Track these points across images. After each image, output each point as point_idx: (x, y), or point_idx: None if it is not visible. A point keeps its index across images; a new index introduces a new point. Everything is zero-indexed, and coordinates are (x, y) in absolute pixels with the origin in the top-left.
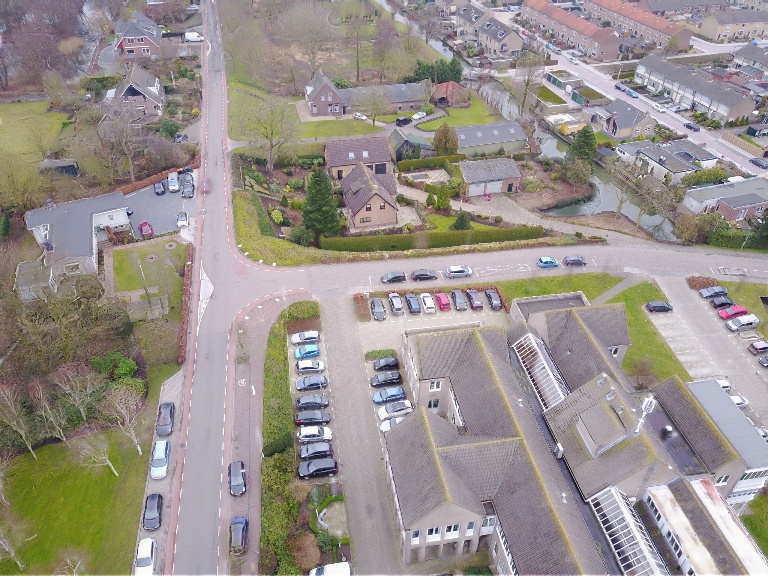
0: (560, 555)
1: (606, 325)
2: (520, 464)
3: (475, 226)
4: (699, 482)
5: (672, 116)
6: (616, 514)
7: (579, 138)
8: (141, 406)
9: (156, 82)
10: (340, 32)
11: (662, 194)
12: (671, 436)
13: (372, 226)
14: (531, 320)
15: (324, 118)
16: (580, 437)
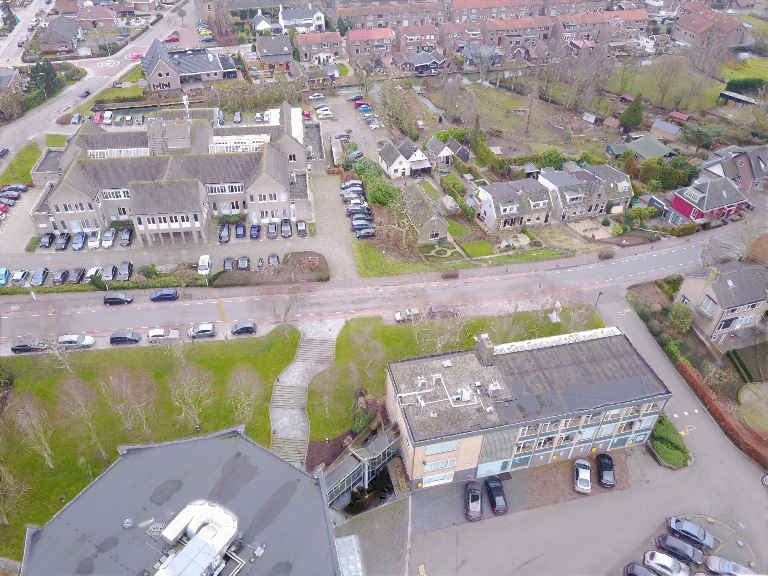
0: (239, 158)
1: None
2: (186, 162)
3: None
4: None
5: None
6: (223, 149)
7: None
8: None
9: None
10: None
11: None
12: None
13: None
14: (64, 163)
15: None
16: (176, 149)
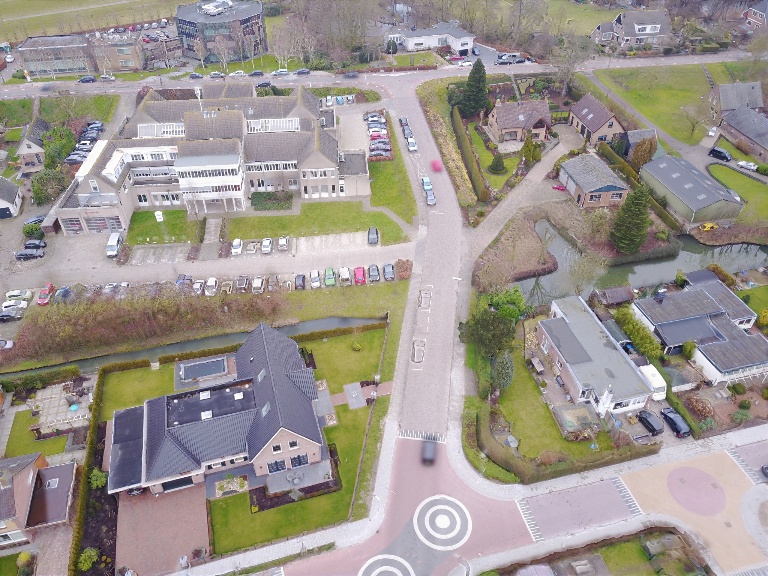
0: None
1: None
2: None
3: (503, 176)
4: None
5: None
6: None
7: None
8: (312, 69)
9: (651, 26)
10: None
11: (593, 297)
12: None
13: None
14: None
15: None
16: None
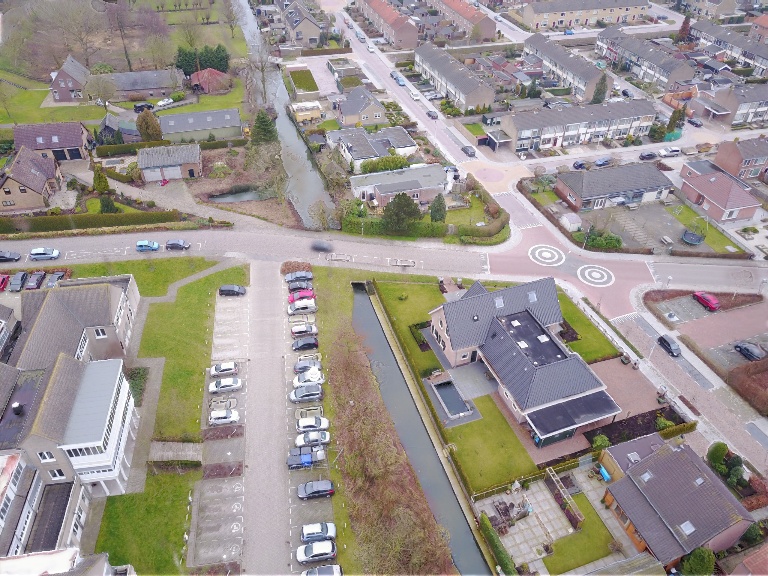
0: None
1: (86, 306)
2: None
3: (126, 211)
4: (7, 457)
5: (423, 104)
6: None
7: (255, 124)
8: None
9: None
10: (105, 18)
11: None
12: (19, 413)
13: (19, 210)
14: None
15: (66, 104)
16: None
